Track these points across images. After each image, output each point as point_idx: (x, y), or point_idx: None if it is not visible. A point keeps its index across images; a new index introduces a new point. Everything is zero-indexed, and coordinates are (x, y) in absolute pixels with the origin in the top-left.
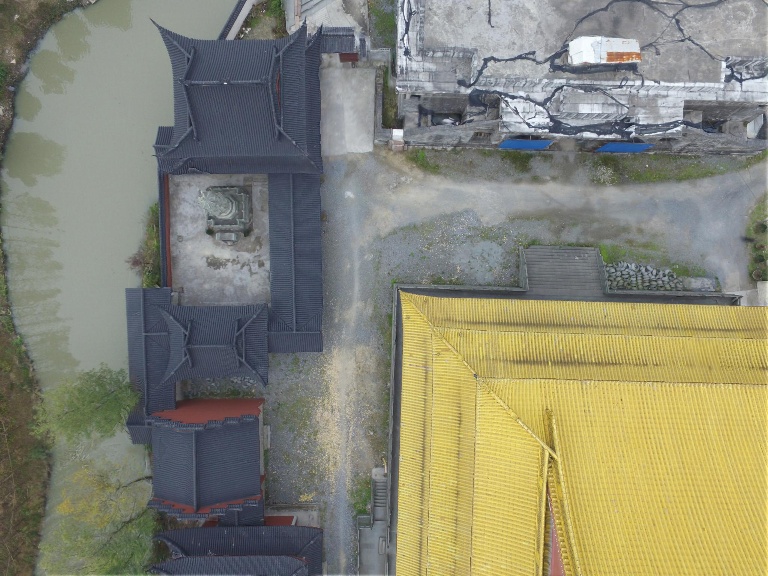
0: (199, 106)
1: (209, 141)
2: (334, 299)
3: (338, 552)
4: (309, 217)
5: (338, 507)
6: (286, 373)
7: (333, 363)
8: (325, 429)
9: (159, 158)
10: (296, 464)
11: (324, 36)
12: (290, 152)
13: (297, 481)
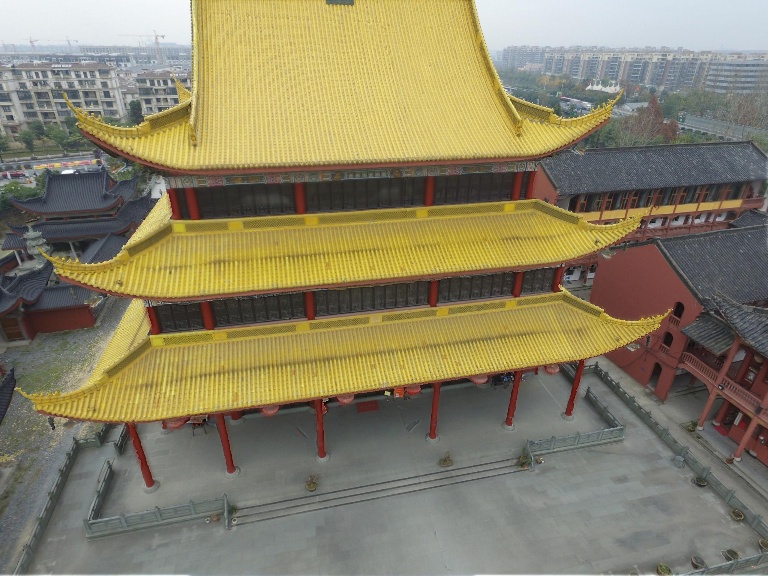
0: (54, 189)
1: (53, 205)
2: (125, 306)
3: (21, 526)
4: (117, 249)
5: (53, 461)
6: (47, 353)
7: (107, 339)
8: (73, 386)
9: (6, 241)
10: (11, 425)
11: (154, 201)
12: (110, 203)
13: (1, 442)
